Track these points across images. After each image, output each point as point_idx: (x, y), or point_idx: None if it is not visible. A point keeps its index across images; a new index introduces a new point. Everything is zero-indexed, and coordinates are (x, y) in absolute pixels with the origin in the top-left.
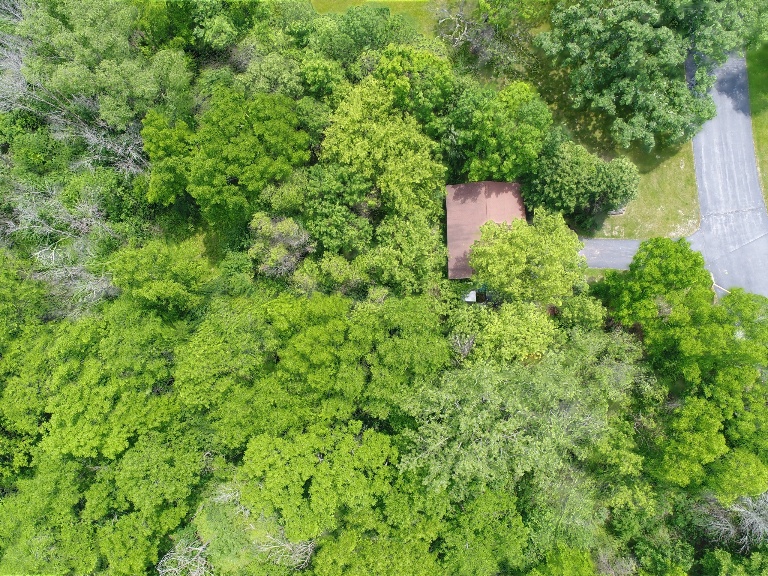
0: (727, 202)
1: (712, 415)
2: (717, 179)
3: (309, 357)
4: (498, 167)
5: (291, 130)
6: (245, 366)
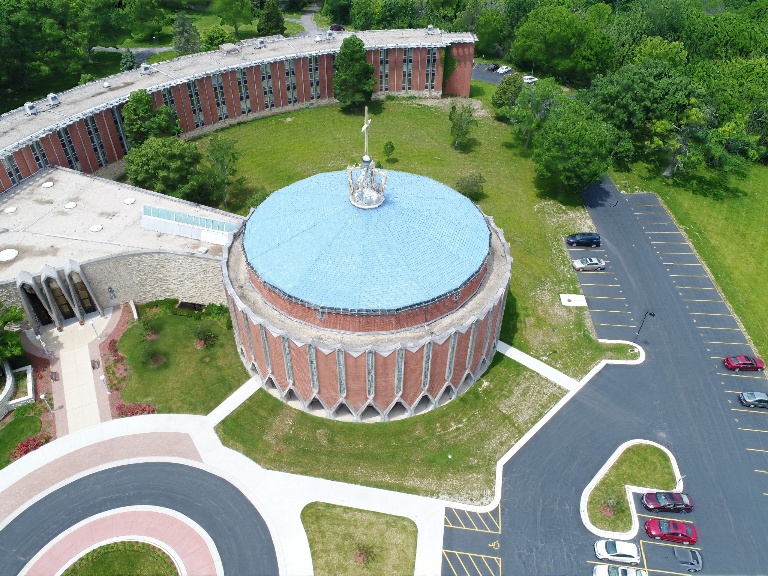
0: None
1: None
2: None
3: (740, 23)
4: None
5: None
6: None
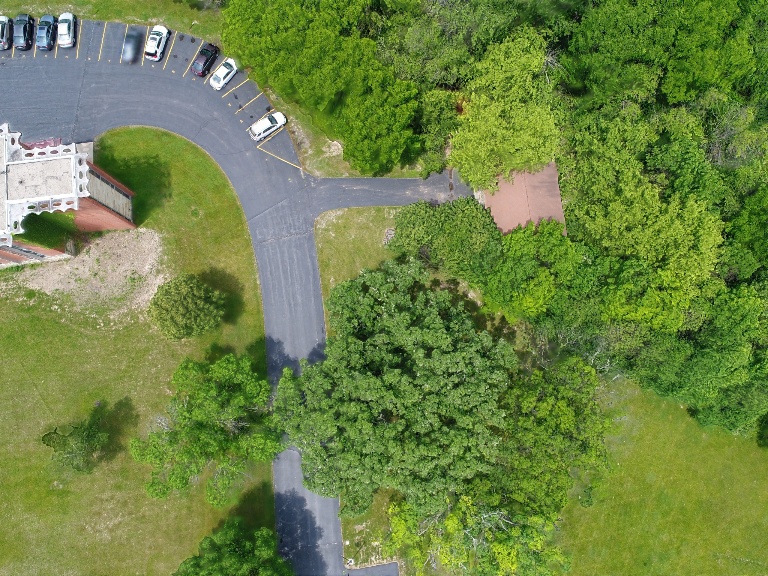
0: (289, 247)
1: (342, 1)
2: (299, 269)
3: (712, 5)
4: (538, 227)
5: (761, 232)
6: (761, 6)
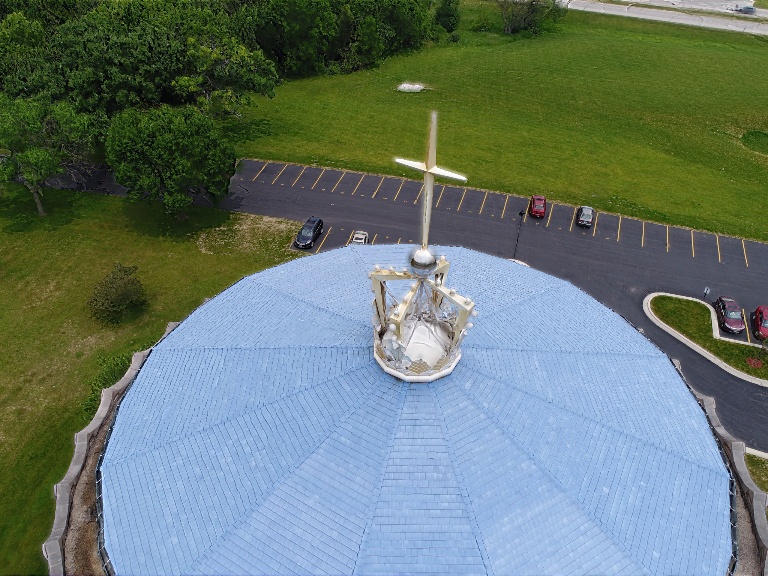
0: None
1: None
2: None
3: None
4: None
5: None
6: None
